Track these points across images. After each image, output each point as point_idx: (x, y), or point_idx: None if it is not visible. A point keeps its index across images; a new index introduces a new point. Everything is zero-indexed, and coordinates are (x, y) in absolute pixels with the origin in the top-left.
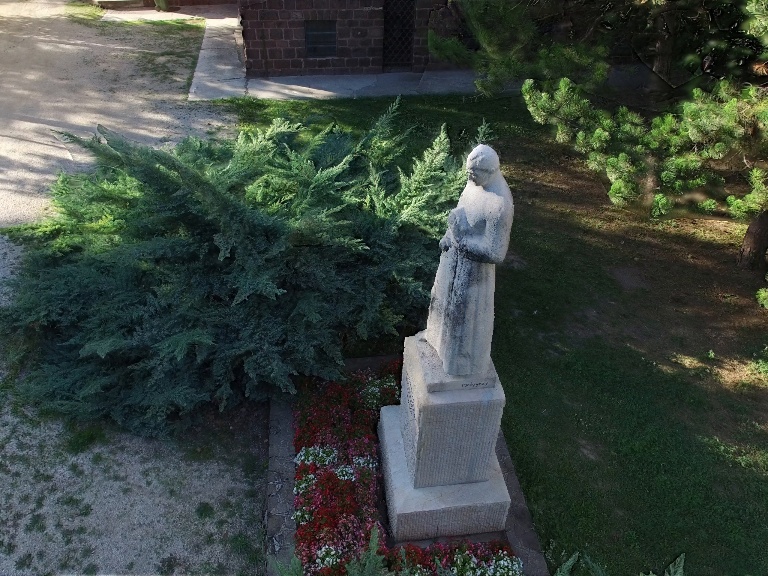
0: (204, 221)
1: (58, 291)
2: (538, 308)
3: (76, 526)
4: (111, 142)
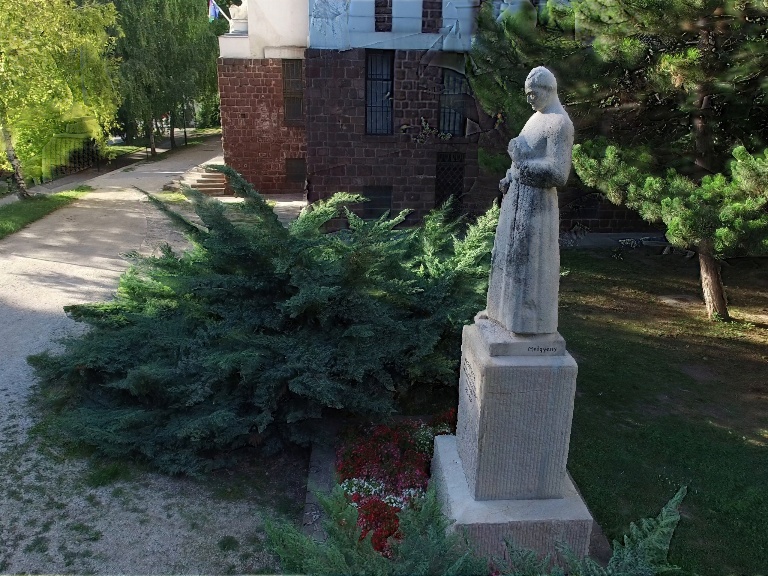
0: (262, 266)
1: (109, 345)
2: (603, 390)
3: (82, 549)
4: (186, 192)
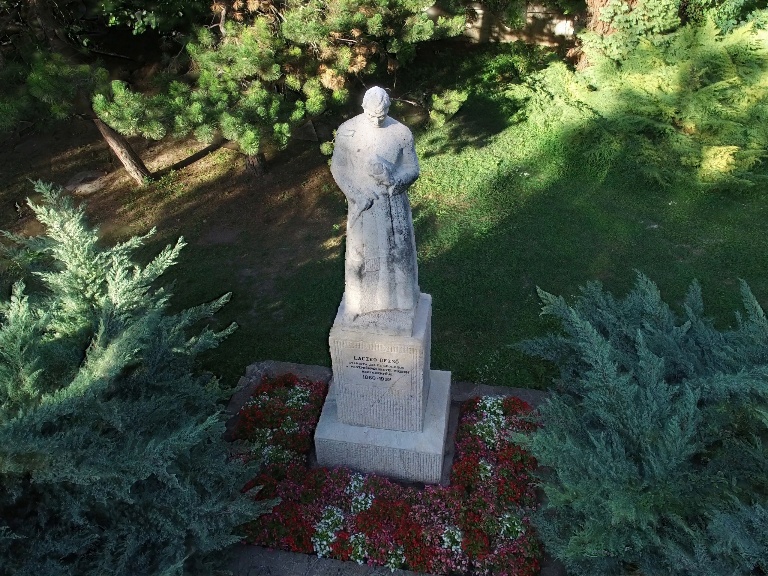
0: None
1: None
2: None
3: None
4: None
